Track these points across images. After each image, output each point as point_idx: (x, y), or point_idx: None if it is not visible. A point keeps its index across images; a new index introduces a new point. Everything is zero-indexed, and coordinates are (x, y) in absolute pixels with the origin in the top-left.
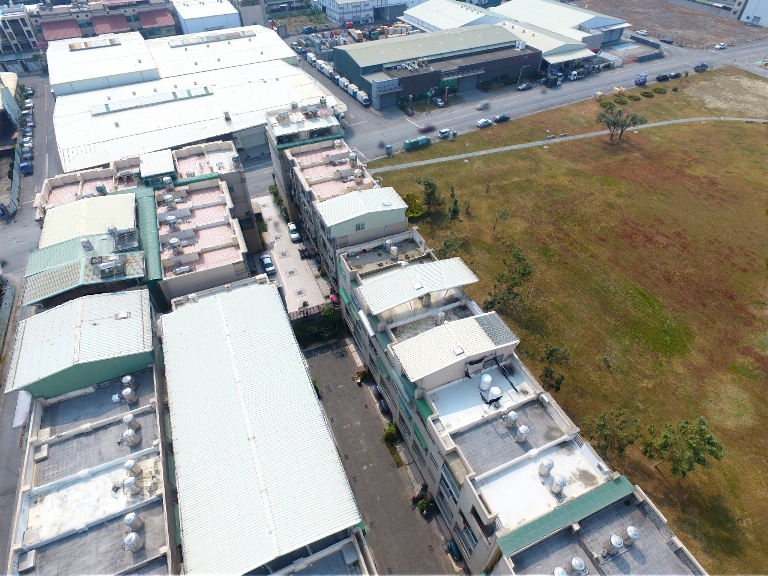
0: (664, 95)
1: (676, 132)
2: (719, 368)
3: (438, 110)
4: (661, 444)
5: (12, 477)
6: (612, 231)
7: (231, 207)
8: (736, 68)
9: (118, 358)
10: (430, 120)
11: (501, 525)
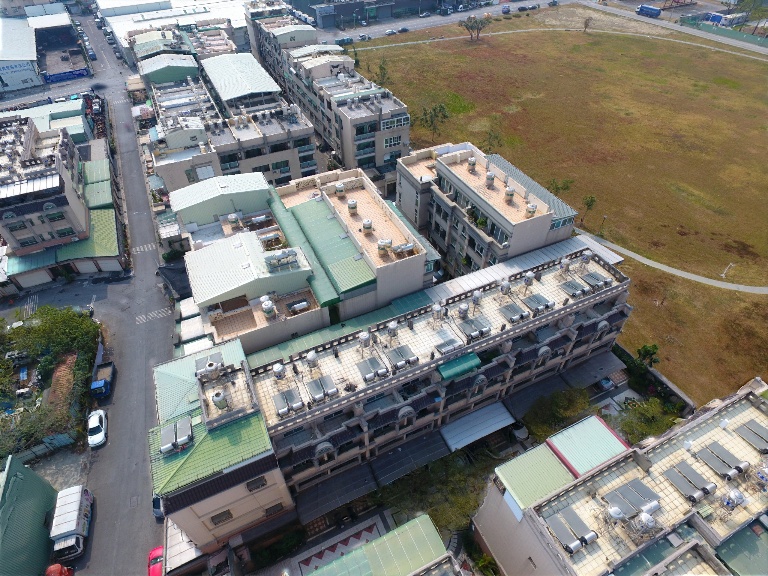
0: (519, 18)
1: (516, 36)
2: (481, 116)
3: (362, 28)
4: (423, 114)
5: (130, 148)
6: (452, 76)
7: (228, 37)
8: (578, 4)
9: (185, 67)
10: (355, 32)
11: (333, 96)
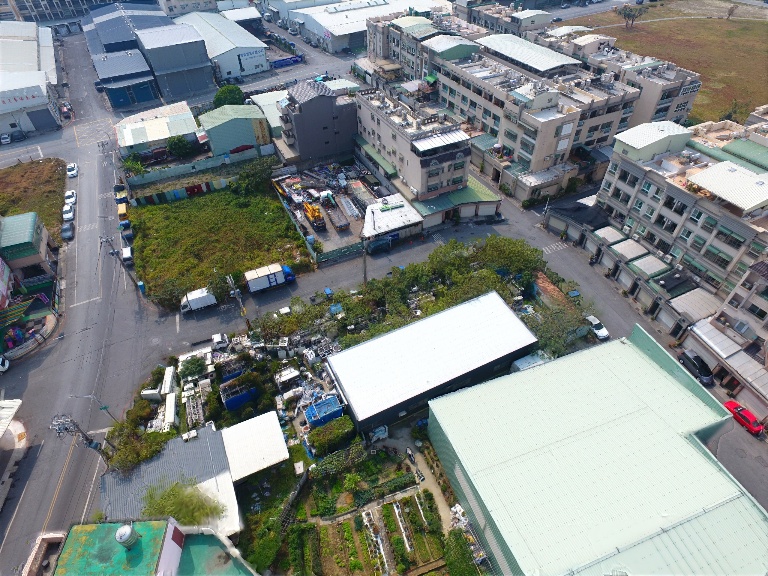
0: (655, 8)
1: (665, 23)
2: None
3: None
4: None
5: None
6: None
7: None
8: None
9: (470, 46)
10: None
11: None
